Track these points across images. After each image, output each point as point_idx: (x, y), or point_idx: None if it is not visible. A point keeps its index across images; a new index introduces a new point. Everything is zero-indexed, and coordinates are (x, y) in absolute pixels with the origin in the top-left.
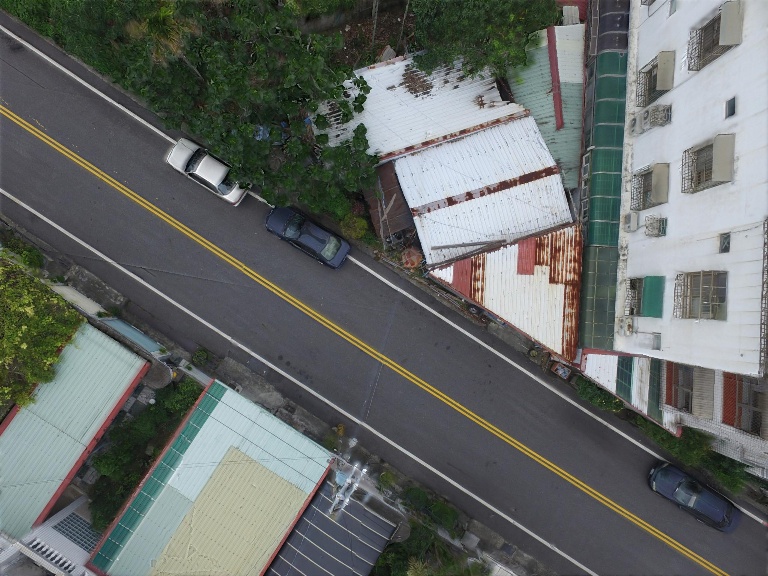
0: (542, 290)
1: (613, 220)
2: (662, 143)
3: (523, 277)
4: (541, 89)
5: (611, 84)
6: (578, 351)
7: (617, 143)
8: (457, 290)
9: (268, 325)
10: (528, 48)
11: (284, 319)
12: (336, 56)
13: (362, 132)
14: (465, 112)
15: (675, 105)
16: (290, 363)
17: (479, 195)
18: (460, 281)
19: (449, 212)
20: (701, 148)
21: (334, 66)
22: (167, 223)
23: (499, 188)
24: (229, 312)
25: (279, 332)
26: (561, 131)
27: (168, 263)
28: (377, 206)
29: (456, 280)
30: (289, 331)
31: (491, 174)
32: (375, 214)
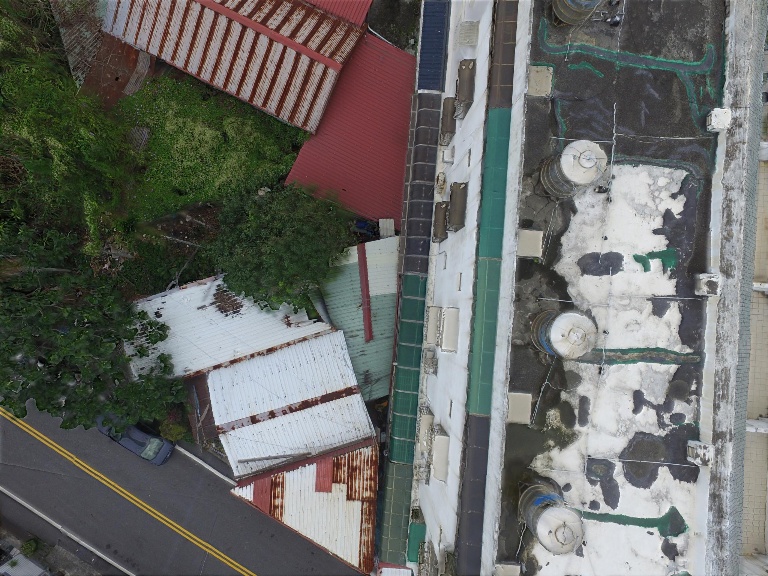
0: (340, 506)
1: (410, 438)
2: (434, 391)
3: (321, 494)
4: (352, 303)
5: (412, 306)
6: (378, 560)
7: (416, 364)
8: (257, 506)
9: (97, 515)
10: (340, 263)
11: (113, 509)
12: (176, 246)
13: (164, 360)
14: (273, 330)
15: (439, 363)
16: (117, 552)
17: (282, 414)
18: (260, 498)
19: (253, 429)
20: (442, 426)
21: (174, 256)
22: (1, 416)
23: (301, 407)
24: (60, 502)
25: (107, 522)
26: (371, 343)
27: (2, 454)
28: (194, 412)
29: (256, 498)
30: (117, 521)
31: (295, 392)
32: (193, 419)
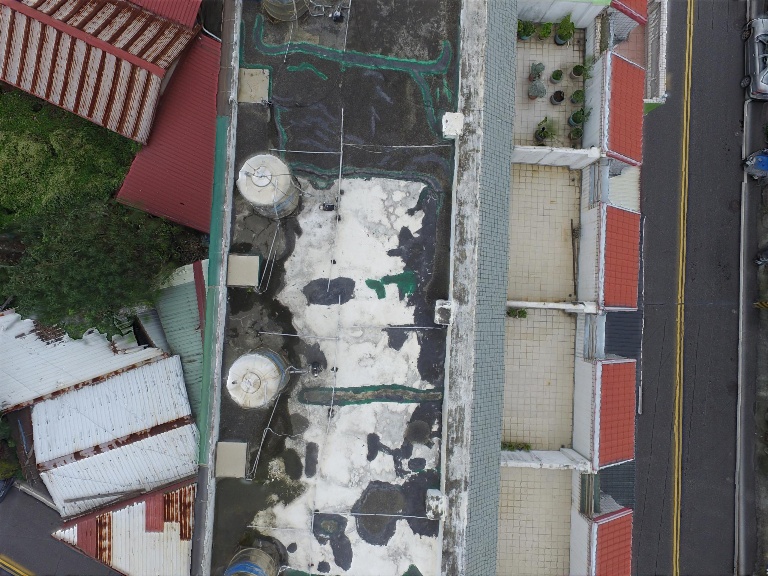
0: (173, 546)
1: None
2: None
3: (152, 534)
4: (190, 325)
5: None
6: None
7: None
8: (82, 550)
9: None
10: (176, 283)
11: None
12: None
13: None
14: (99, 358)
15: None
16: None
17: (108, 449)
18: (85, 541)
19: (78, 466)
20: None
21: None
22: None
23: (129, 441)
24: None
25: None
26: None
27: None
28: (22, 448)
29: (80, 541)
30: None
31: (124, 424)
32: (21, 456)
